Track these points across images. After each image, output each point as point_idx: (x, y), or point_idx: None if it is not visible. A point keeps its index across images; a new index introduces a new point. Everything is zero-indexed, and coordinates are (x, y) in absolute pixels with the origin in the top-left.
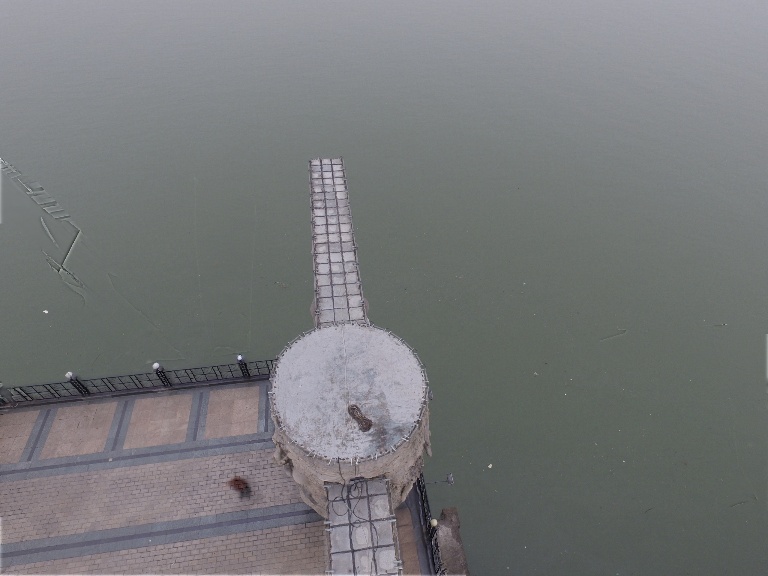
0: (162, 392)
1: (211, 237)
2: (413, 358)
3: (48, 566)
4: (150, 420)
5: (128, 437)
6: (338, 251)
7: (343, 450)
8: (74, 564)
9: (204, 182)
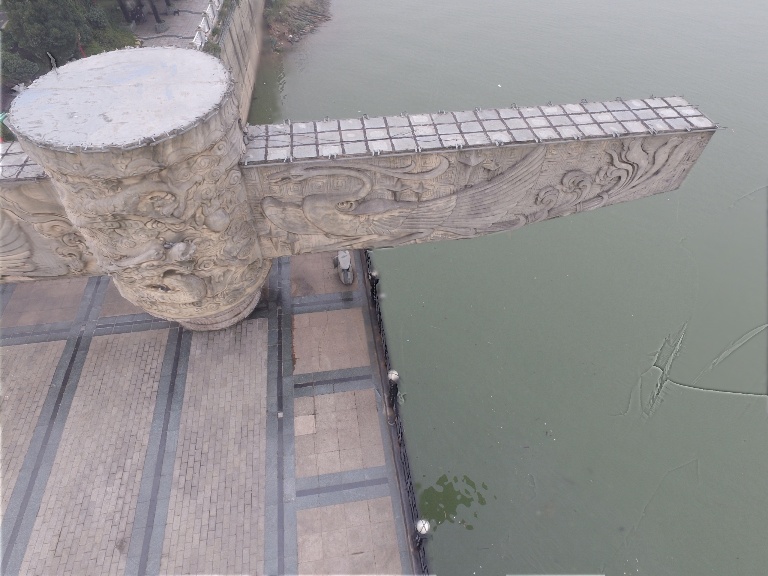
0: None
1: None
2: None
3: None
4: None
5: None
6: None
7: None
8: None
9: None
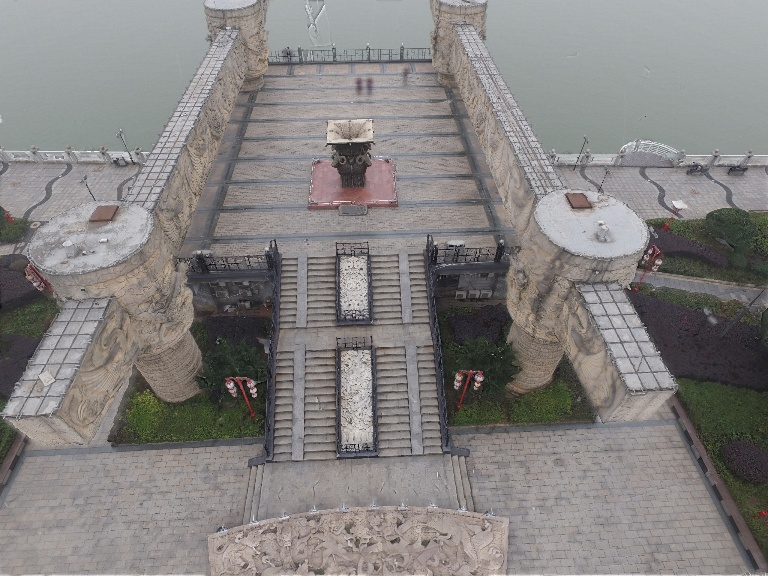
0: (366, 63)
1: (380, 13)
2: None
3: None
4: (364, 68)
5: (356, 71)
6: None
7: (462, 4)
8: None
9: None
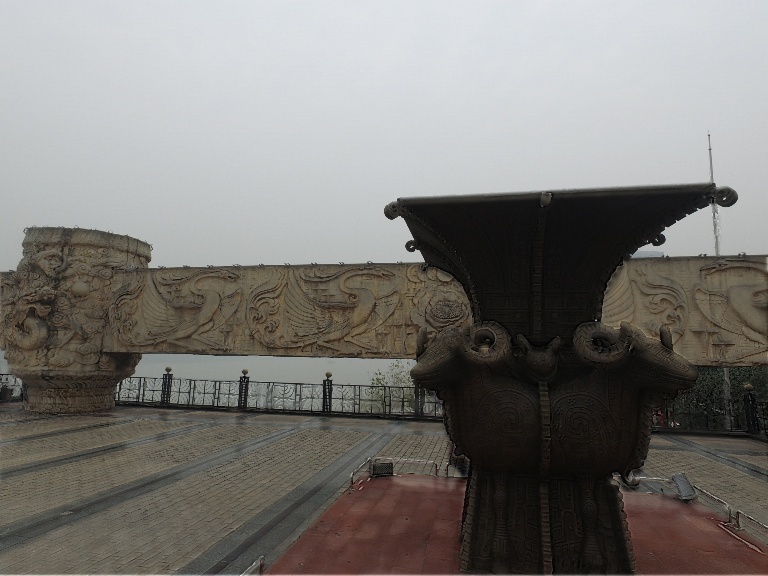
0: None
1: None
2: None
3: None
4: None
5: None
6: None
7: None
8: None
9: None
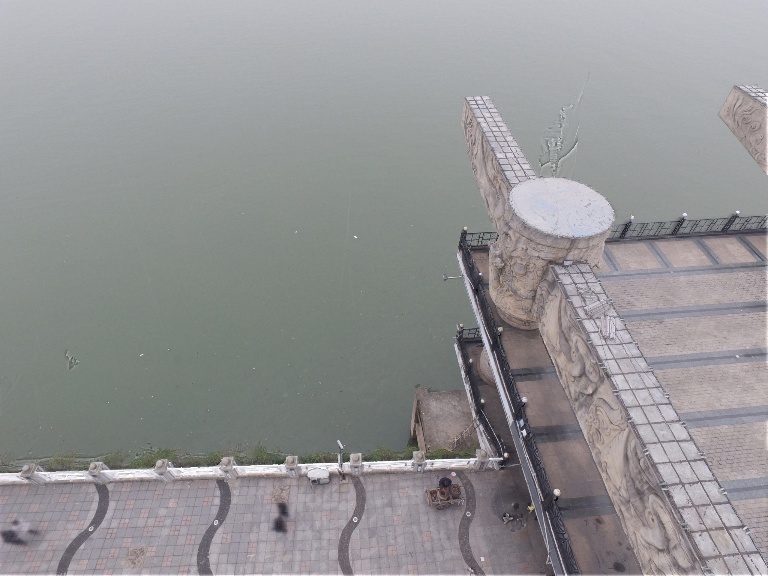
0: (669, 239)
1: (653, 143)
2: None
3: (688, 320)
4: (677, 253)
5: (671, 261)
6: None
7: None
8: (704, 319)
9: (674, 98)
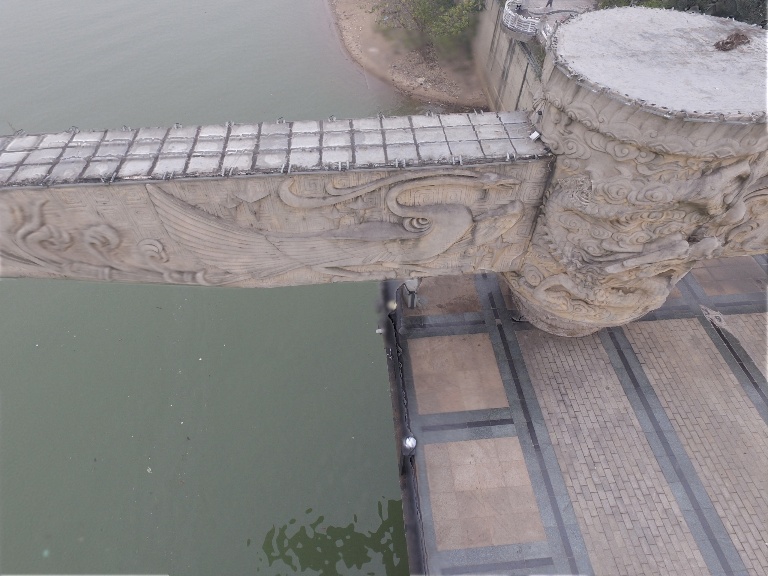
0: None
1: None
2: (600, 11)
3: None
4: None
5: None
6: (286, 140)
7: None
8: None
9: None
